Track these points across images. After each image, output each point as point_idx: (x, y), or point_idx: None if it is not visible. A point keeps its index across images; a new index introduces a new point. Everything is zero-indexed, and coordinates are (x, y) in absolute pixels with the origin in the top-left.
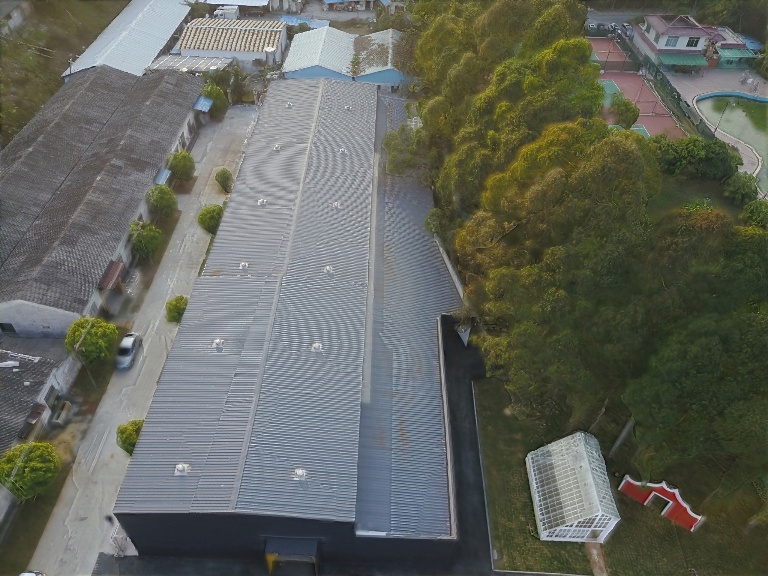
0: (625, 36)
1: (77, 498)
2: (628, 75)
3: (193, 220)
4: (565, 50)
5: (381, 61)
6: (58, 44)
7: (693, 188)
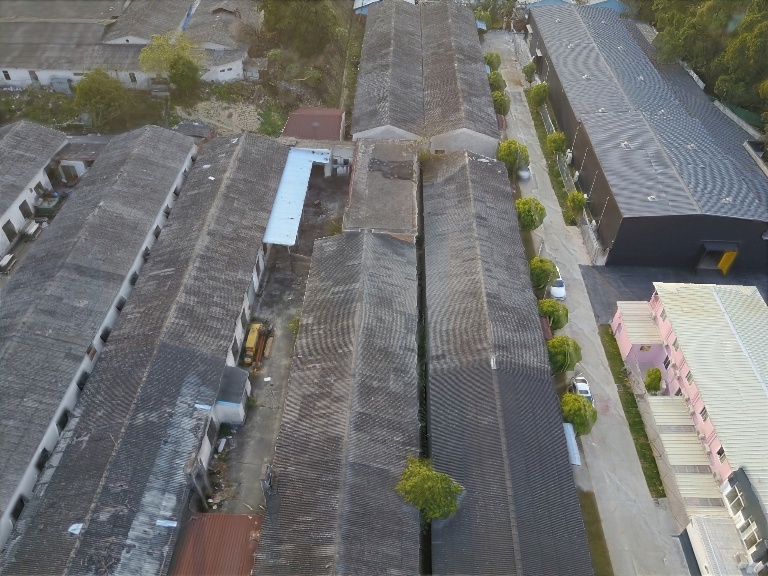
0: None
1: (545, 240)
2: None
3: None
4: None
5: None
6: None
7: None
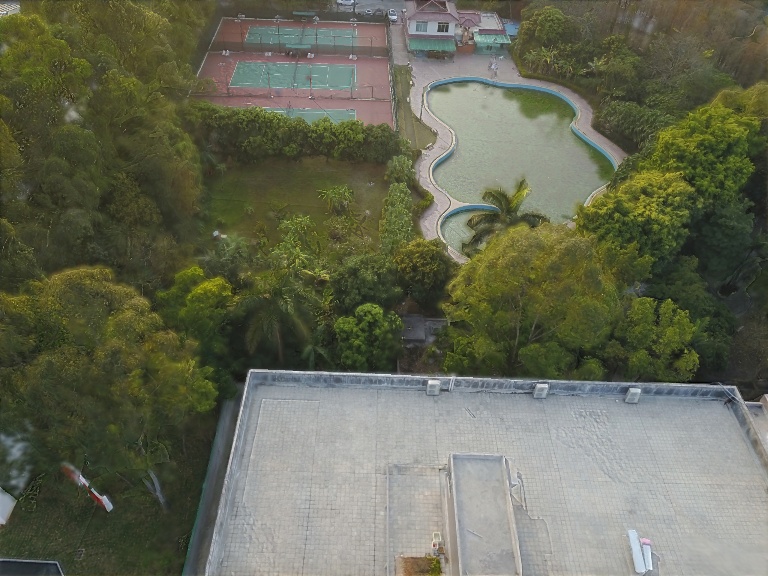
0: (401, 22)
1: None
2: (375, 60)
3: None
4: (2, 25)
5: None
6: None
7: (364, 172)
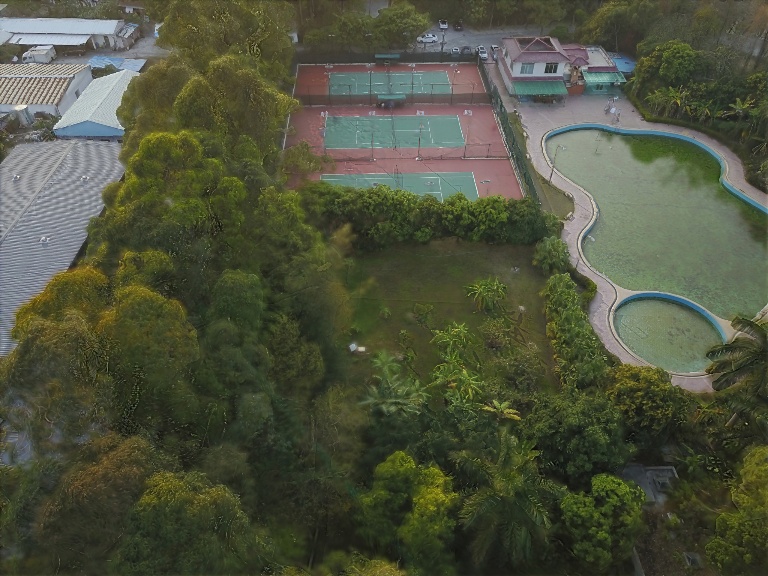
0: (492, 60)
1: None
2: (478, 108)
3: None
4: (146, 150)
5: None
6: None
7: (503, 254)
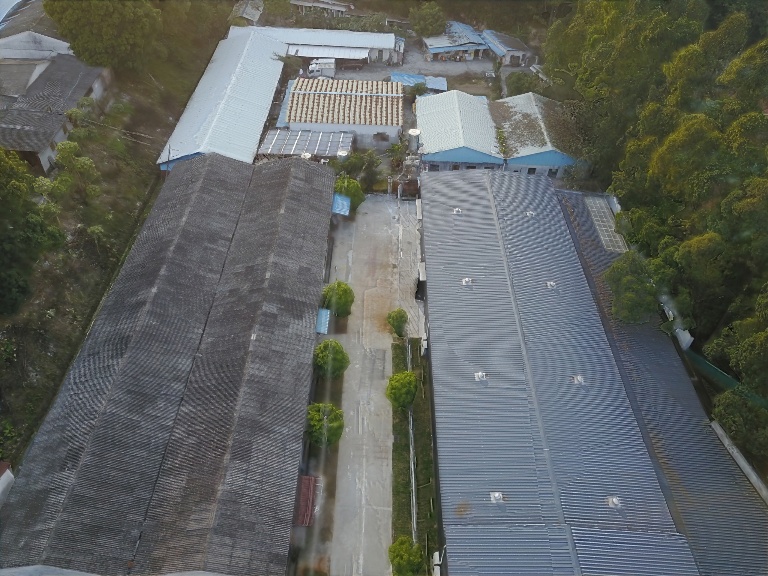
0: None
1: None
2: None
3: (362, 376)
4: None
5: (535, 138)
6: (144, 118)
7: None
